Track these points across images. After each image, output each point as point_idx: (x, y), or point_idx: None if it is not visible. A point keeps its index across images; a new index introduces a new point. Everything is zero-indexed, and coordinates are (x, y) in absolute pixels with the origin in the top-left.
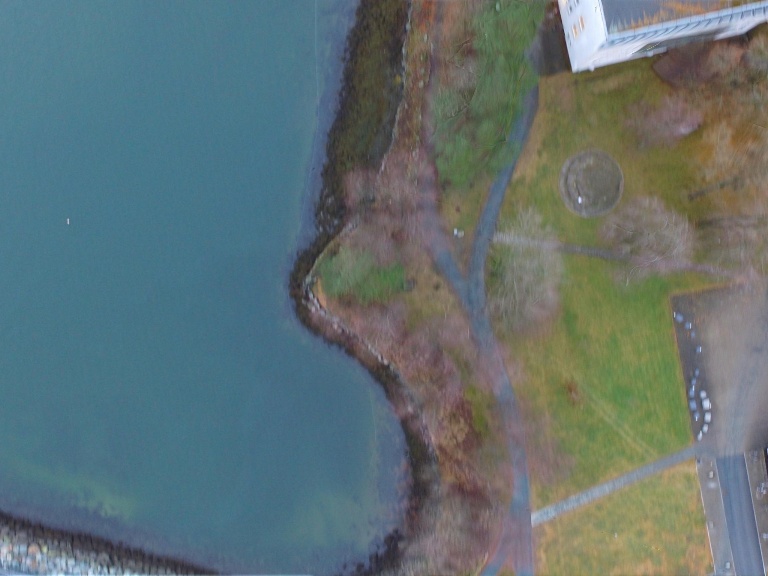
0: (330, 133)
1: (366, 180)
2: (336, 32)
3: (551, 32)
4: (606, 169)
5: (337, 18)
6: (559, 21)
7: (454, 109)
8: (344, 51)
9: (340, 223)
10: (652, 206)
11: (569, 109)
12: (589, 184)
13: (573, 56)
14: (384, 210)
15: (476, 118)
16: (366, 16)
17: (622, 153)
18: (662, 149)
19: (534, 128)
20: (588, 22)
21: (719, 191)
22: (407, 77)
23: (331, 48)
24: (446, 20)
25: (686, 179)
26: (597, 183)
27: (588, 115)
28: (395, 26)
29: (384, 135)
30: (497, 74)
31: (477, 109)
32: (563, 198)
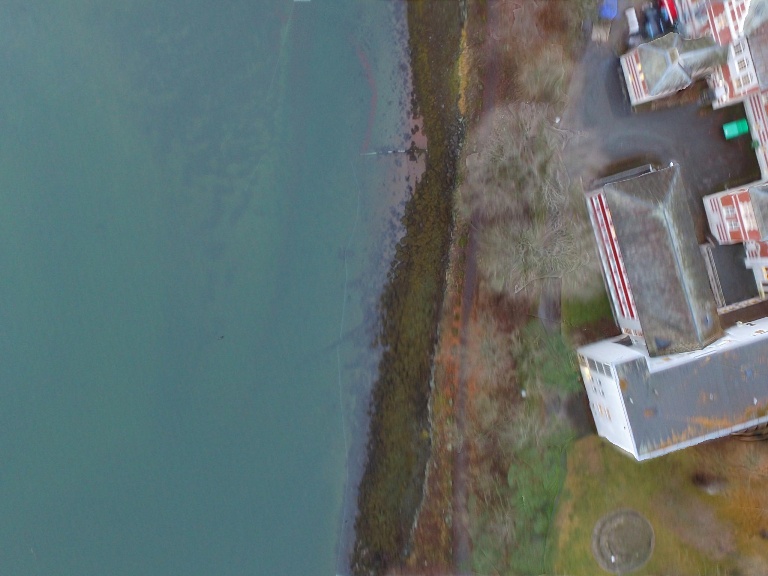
0: (360, 487)
1: (399, 534)
2: (360, 386)
3: (575, 400)
4: (637, 527)
5: (360, 372)
6: (583, 387)
7: (486, 492)
8: (369, 405)
9: (376, 575)
10: (684, 560)
11: (597, 472)
12: (621, 543)
13: (599, 425)
14: (420, 573)
15: (518, 573)
16: (389, 370)
17: (651, 510)
18: (691, 507)
19: (564, 493)
20: (616, 424)
21: (748, 541)
22: (434, 436)
23: (356, 401)
24: (470, 386)
25: (716, 534)
26: (629, 541)
27: (616, 476)
28: (419, 381)
29: (414, 488)
30: (536, 535)
31: (517, 560)
32: (596, 558)
